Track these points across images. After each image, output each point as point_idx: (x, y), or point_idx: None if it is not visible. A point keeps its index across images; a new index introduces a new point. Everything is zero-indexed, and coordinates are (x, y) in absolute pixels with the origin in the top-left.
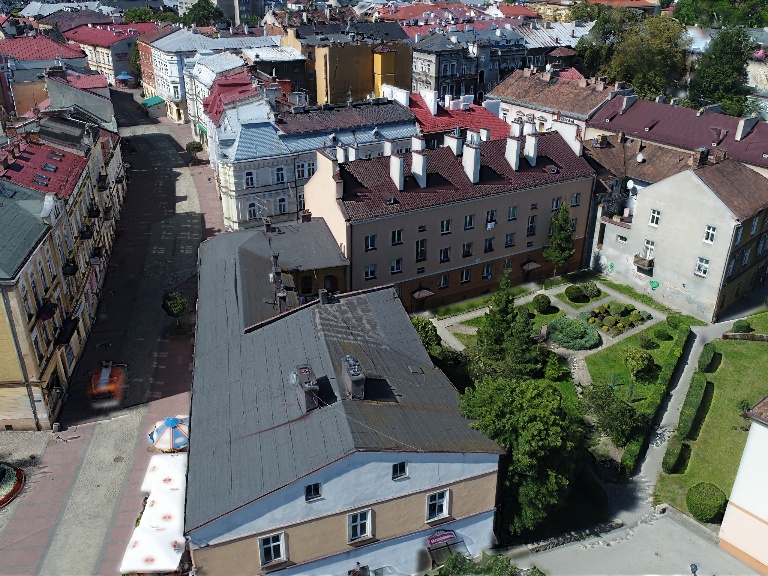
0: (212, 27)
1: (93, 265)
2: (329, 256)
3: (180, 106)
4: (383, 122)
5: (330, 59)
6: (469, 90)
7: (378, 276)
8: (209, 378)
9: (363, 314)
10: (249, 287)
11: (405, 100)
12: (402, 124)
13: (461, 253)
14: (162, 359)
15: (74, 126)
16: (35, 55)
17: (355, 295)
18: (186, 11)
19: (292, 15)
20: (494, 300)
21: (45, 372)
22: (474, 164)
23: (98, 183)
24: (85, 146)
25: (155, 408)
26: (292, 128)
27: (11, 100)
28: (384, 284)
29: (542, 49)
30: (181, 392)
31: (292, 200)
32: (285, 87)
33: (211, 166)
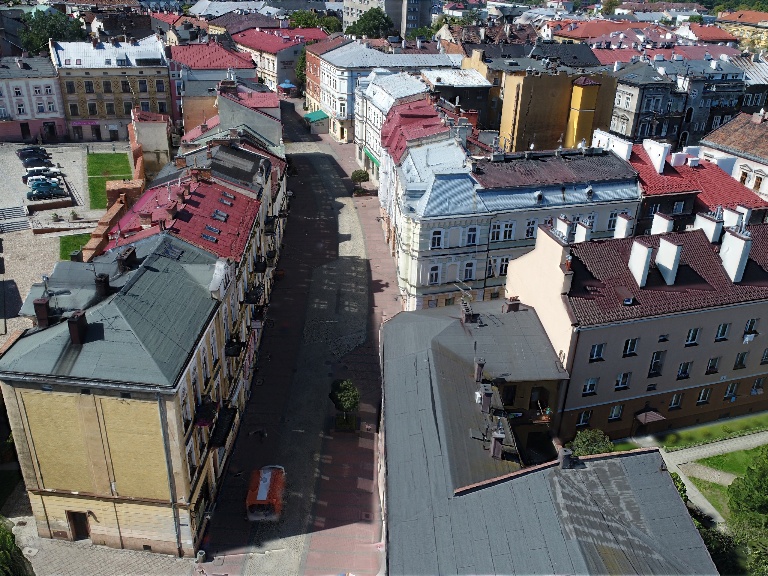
0: (384, 39)
1: (253, 328)
2: (542, 364)
3: (345, 124)
4: (599, 180)
5: (523, 90)
6: (672, 130)
7: (598, 392)
8: (411, 570)
9: (619, 492)
10: (450, 409)
11: (626, 153)
12: (621, 183)
13: (704, 369)
14: (325, 466)
15: (246, 158)
16: (206, 64)
17: (606, 458)
18: (351, 17)
19: (469, 30)
20: (766, 456)
21: (195, 487)
22: (740, 259)
23: (265, 226)
24: (257, 185)
25: (317, 544)
26: (492, 181)
27: (178, 109)
28: (604, 401)
29: (764, 86)
30: (348, 522)
31: (481, 265)
32: (471, 119)
33: (381, 204)
